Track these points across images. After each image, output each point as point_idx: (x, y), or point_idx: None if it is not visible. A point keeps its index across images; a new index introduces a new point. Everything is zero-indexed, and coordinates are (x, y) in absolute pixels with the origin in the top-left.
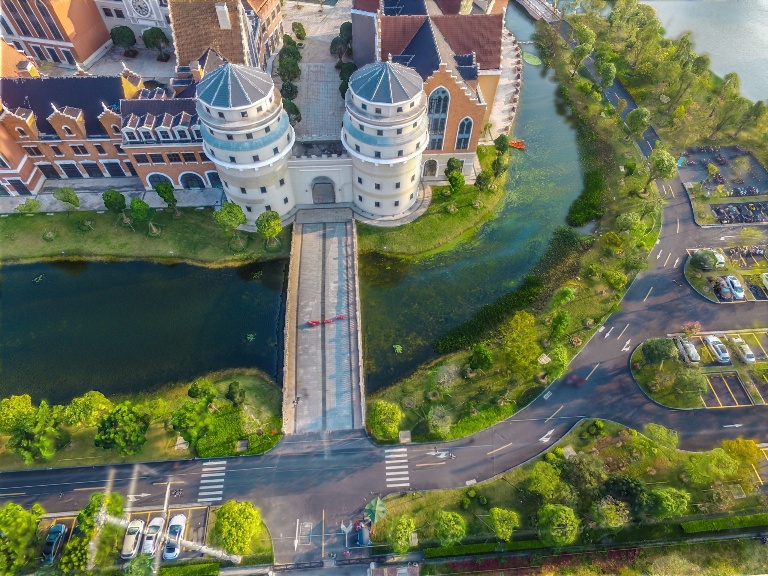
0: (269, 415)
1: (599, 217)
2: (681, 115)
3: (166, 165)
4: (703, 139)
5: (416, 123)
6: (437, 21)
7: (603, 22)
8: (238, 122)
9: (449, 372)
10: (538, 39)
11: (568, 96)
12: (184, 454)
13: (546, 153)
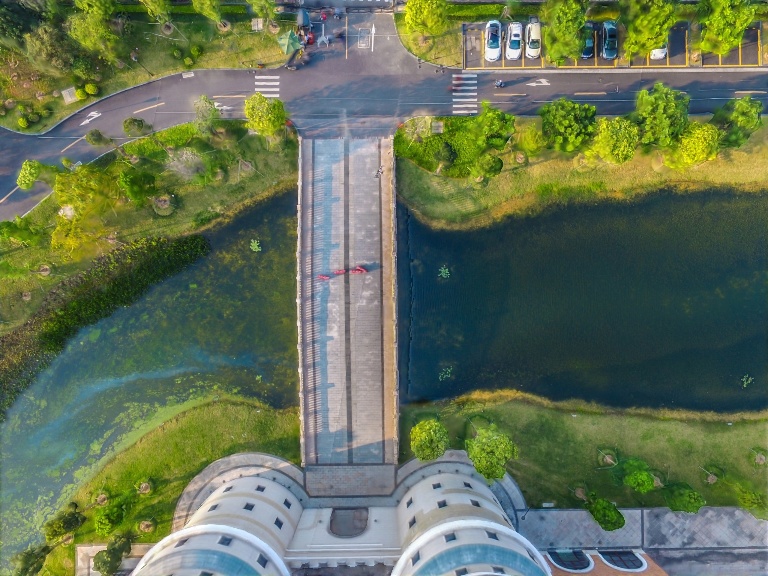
0: (411, 162)
1: None
2: None
3: None
4: None
5: None
6: None
7: None
8: None
9: (179, 160)
10: None
11: None
12: None
13: None
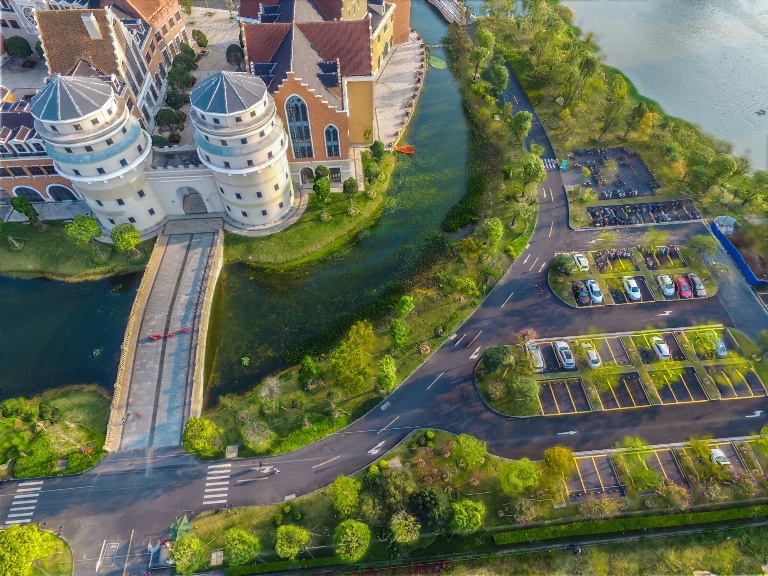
0: (96, 433)
1: (475, 222)
2: (565, 118)
3: (29, 178)
4: (592, 141)
5: (263, 132)
6: (303, 28)
7: (516, 24)
8: (72, 135)
9: (270, 386)
10: (447, 42)
11: (467, 100)
12: (1, 475)
13: (434, 158)
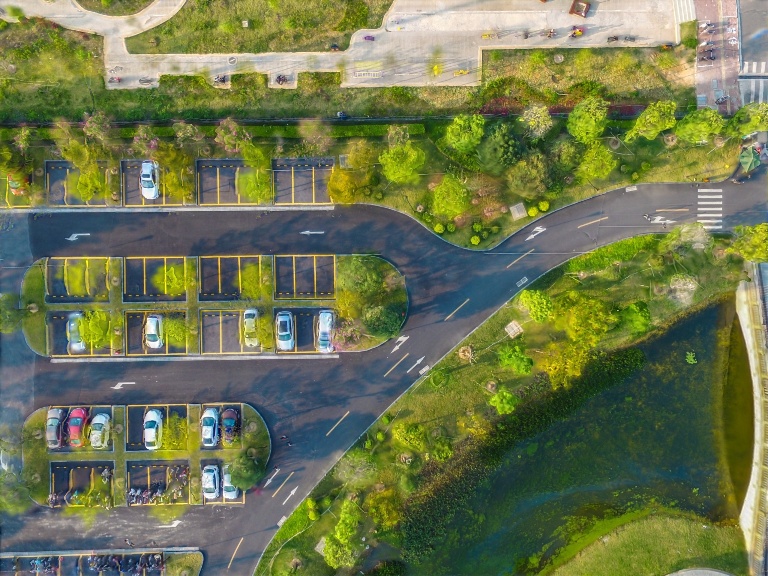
0: None
1: None
2: None
3: None
4: None
5: None
6: None
7: None
8: None
9: (689, 293)
10: None
11: None
12: None
13: None
